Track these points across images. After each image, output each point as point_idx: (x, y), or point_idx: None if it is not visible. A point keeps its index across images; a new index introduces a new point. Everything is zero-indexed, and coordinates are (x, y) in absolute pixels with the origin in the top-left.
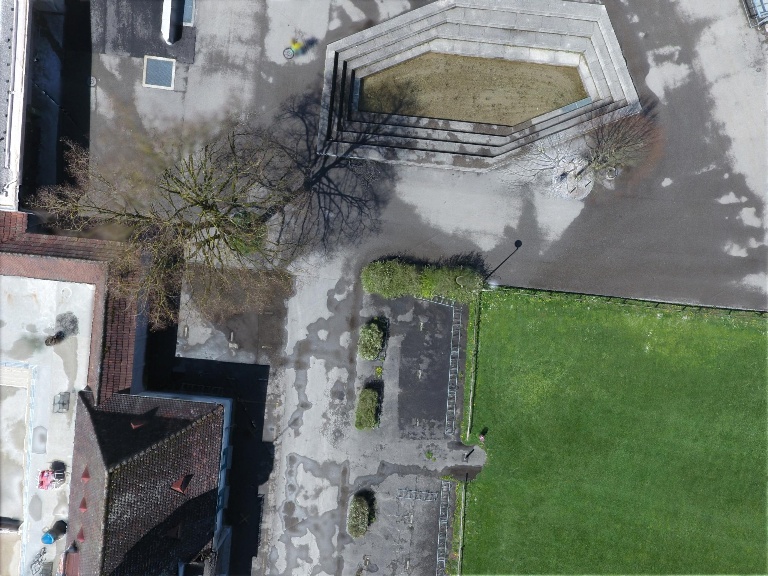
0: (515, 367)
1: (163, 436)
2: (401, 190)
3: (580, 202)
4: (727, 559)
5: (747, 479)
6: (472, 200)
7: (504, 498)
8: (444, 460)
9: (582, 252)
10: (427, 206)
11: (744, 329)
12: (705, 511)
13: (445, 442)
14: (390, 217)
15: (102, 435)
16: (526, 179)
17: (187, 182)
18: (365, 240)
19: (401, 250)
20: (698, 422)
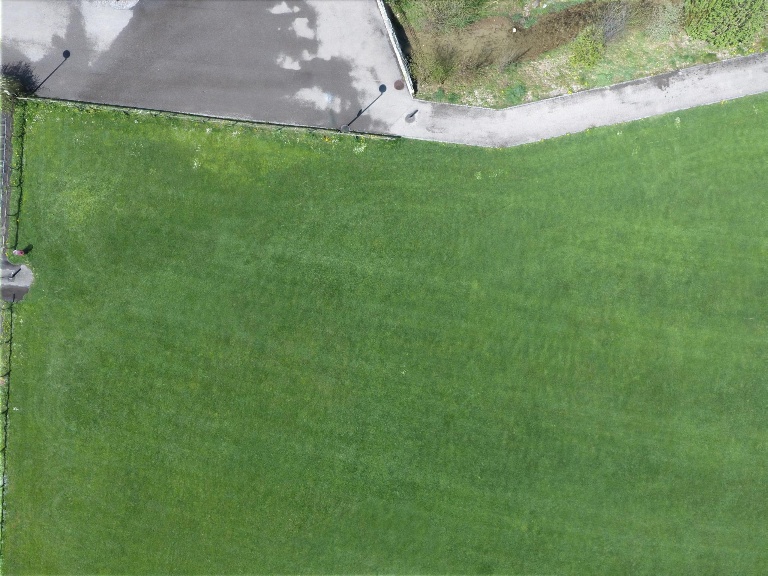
0: (61, 182)
1: None
2: None
3: (129, 11)
4: (282, 391)
5: (301, 305)
6: (18, 7)
7: (50, 320)
8: None
9: (132, 63)
10: None
11: (295, 146)
12: (257, 338)
13: None
14: None
15: None
16: None
17: None
18: None
19: None
20: (249, 243)
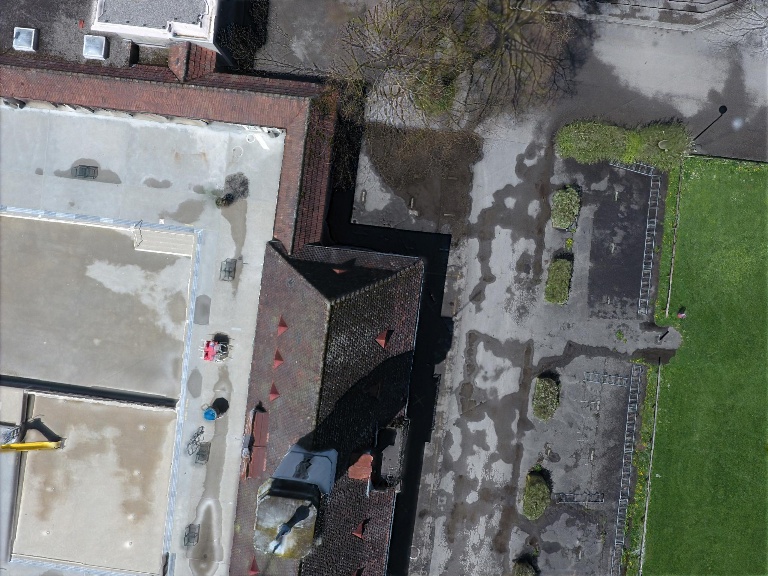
0: (716, 242)
1: (372, 281)
2: (599, 49)
3: None
4: None
5: None
6: (675, 61)
7: (700, 385)
8: (636, 342)
9: None
10: (626, 67)
11: None
12: None
13: (637, 322)
14: (586, 78)
15: (308, 276)
16: (734, 39)
17: (371, 35)
18: (558, 102)
19: (596, 114)
20: None
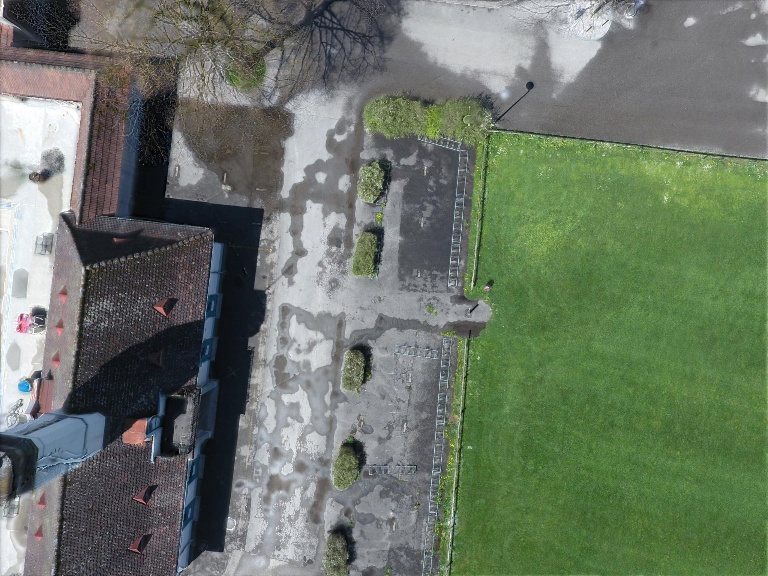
0: (524, 216)
1: (146, 248)
2: (407, 26)
3: (596, 42)
4: (748, 429)
5: None
6: (482, 38)
7: (509, 357)
8: (446, 315)
9: (597, 96)
10: (434, 44)
11: None
12: (725, 376)
13: (447, 296)
14: (395, 55)
15: (82, 244)
16: (539, 16)
17: (183, 12)
18: (368, 78)
19: (405, 90)
20: (719, 279)
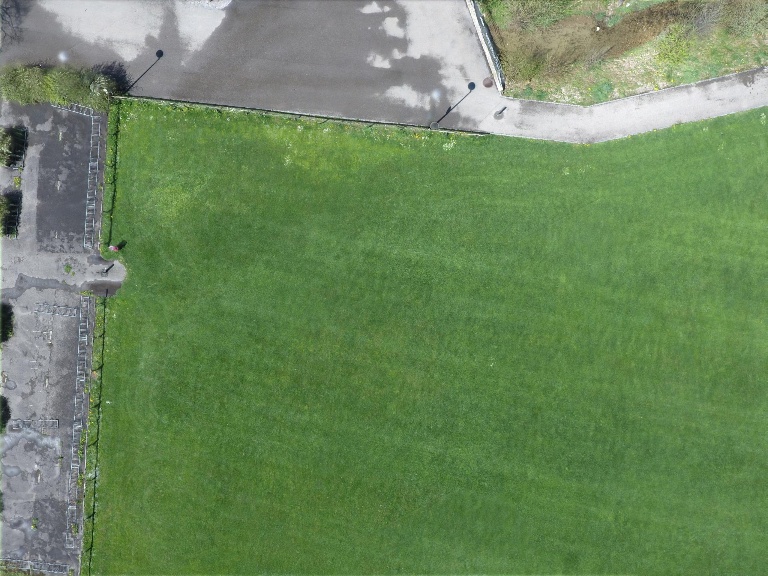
0: (154, 179)
1: None
2: None
3: (221, 11)
4: (371, 384)
5: (390, 299)
6: (113, 8)
7: (143, 315)
8: (83, 275)
9: (224, 63)
10: (68, 14)
11: (386, 142)
12: (347, 332)
13: (85, 256)
14: (31, 25)
15: None
16: None
17: None
18: (6, 48)
19: (42, 59)
20: (339, 239)
